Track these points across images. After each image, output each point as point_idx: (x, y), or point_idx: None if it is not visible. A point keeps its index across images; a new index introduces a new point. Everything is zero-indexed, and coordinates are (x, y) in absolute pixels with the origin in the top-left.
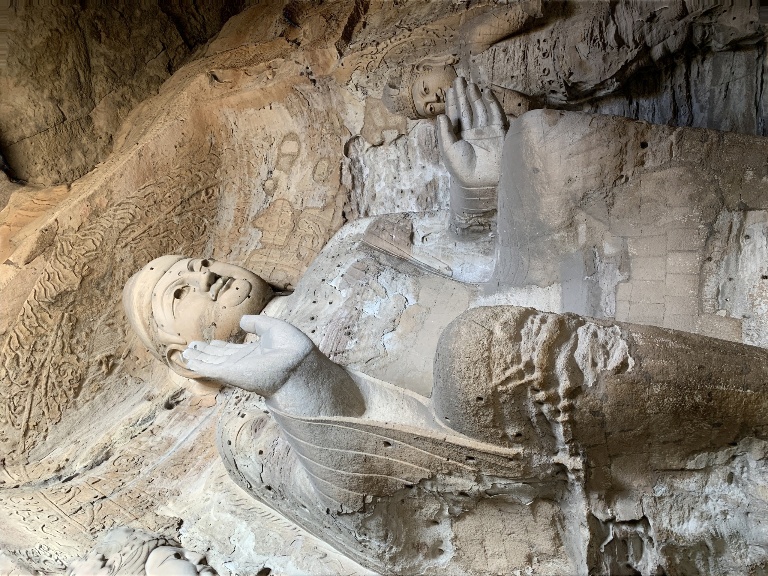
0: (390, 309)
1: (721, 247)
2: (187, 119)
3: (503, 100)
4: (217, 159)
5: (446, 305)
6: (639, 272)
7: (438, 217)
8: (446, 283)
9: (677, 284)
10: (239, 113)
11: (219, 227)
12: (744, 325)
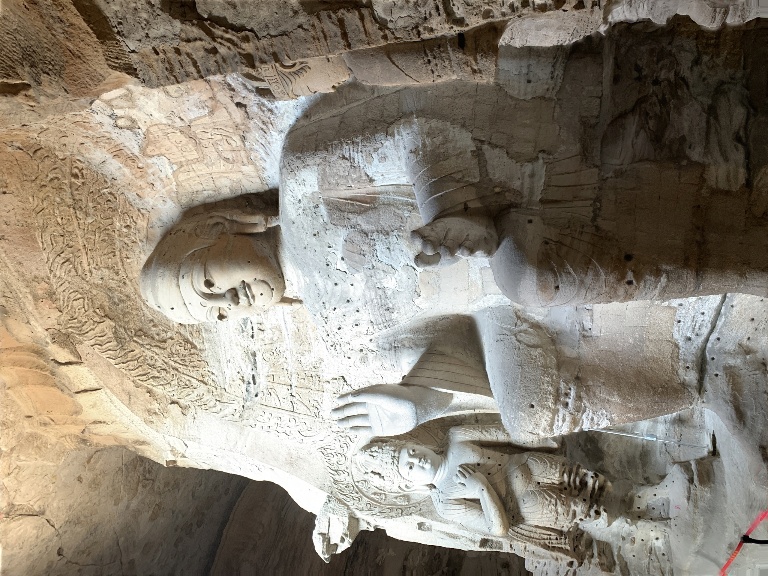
0: (406, 281)
1: None
2: None
3: None
4: (43, 150)
5: (450, 268)
6: None
7: (391, 162)
8: None
9: None
10: None
11: (119, 180)
12: (677, 313)
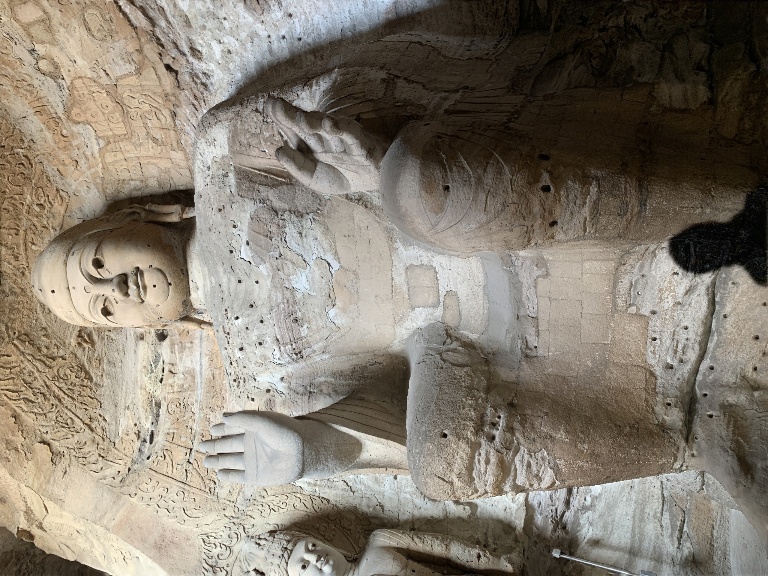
0: (319, 281)
1: (636, 259)
2: None
3: None
4: None
5: (370, 265)
6: (556, 271)
7: None
8: (355, 217)
9: (593, 282)
10: None
11: (39, 144)
12: (650, 326)
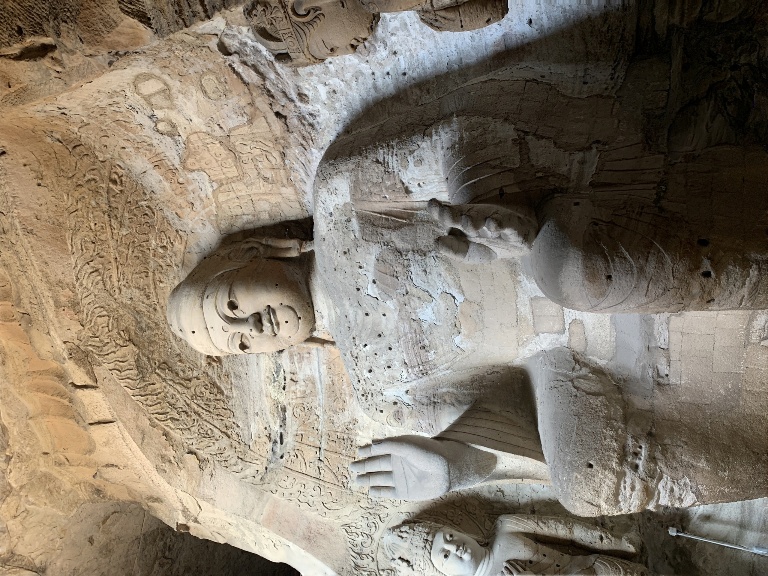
0: (444, 312)
1: None
2: (5, 146)
3: (461, 26)
4: (83, 147)
5: (495, 297)
6: None
7: (427, 166)
8: None
9: (728, 320)
10: (54, 102)
11: (158, 194)
12: None
